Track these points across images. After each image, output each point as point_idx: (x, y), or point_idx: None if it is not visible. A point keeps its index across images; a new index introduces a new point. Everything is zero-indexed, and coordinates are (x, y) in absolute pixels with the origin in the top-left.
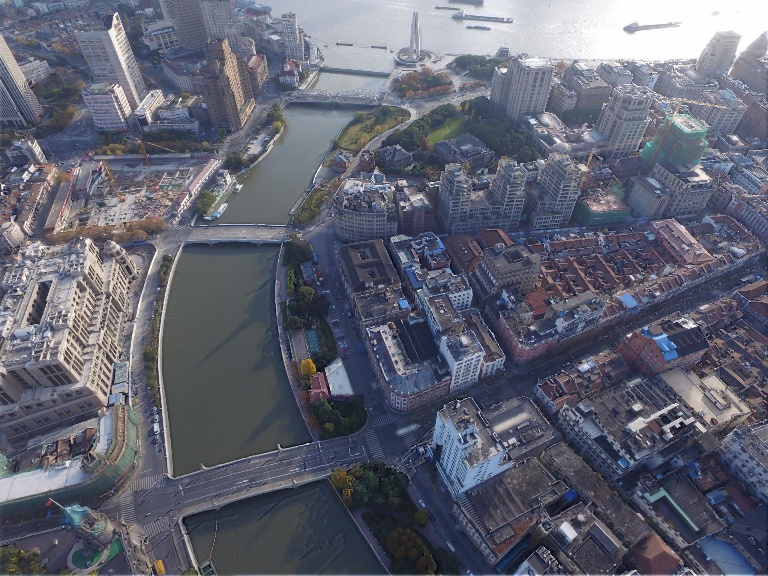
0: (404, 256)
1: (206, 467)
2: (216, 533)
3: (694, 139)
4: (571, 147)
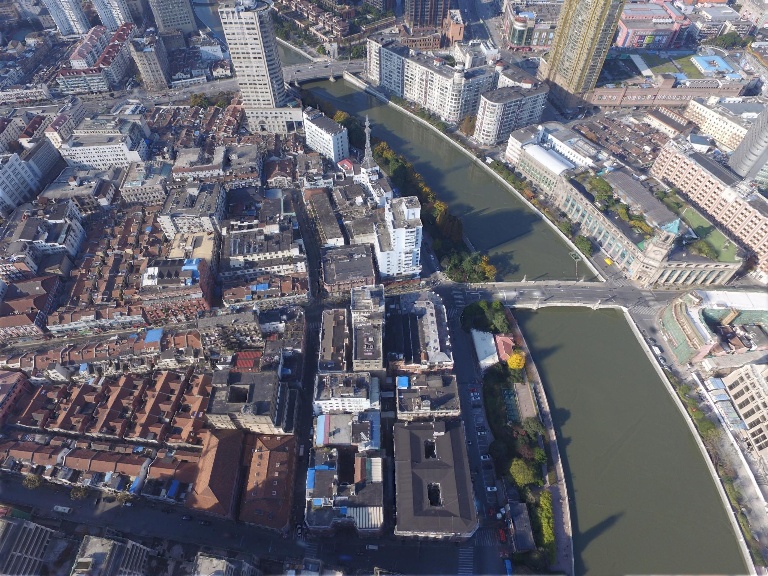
0: (375, 470)
1: (597, 304)
2: (576, 273)
3: None
4: None
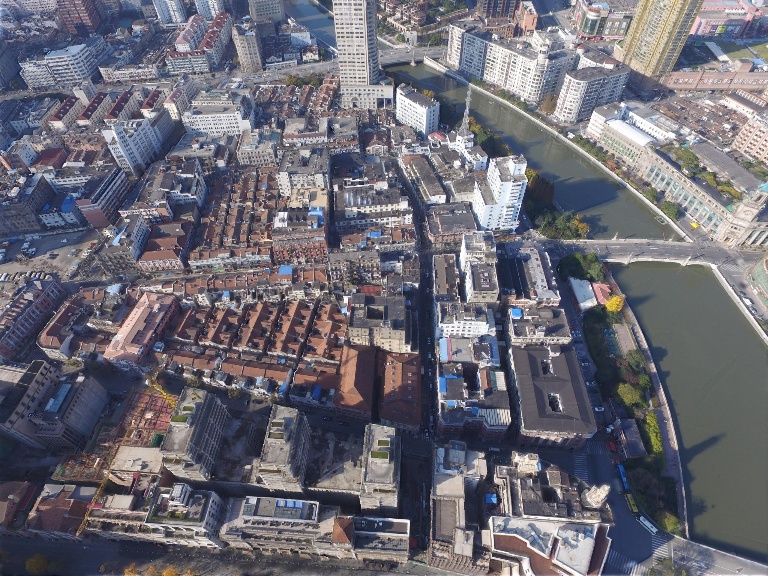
0: (499, 381)
1: (687, 260)
2: (663, 234)
3: None
4: None
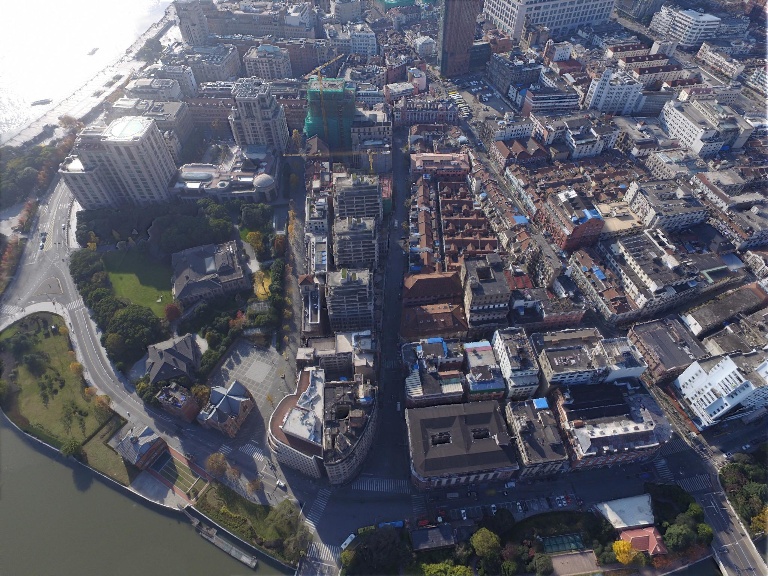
0: (451, 386)
1: None
2: None
3: (344, 92)
4: None
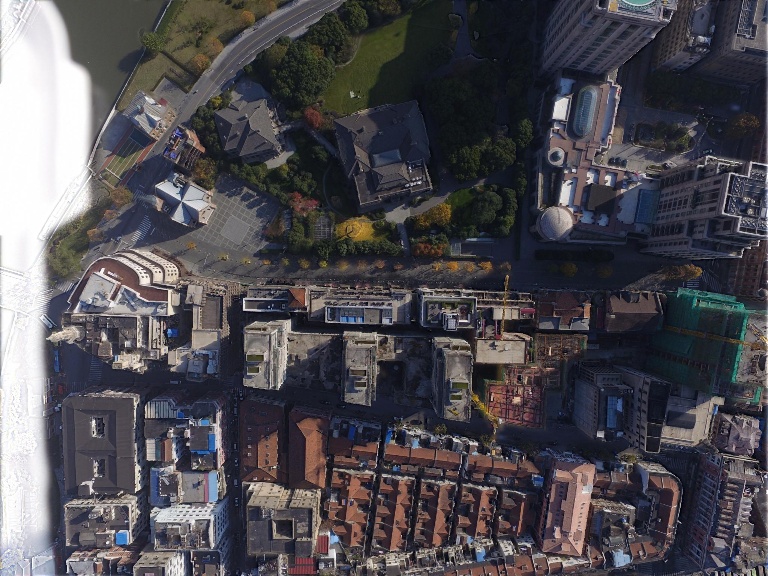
0: (152, 450)
1: None
2: None
3: None
4: (575, 225)
